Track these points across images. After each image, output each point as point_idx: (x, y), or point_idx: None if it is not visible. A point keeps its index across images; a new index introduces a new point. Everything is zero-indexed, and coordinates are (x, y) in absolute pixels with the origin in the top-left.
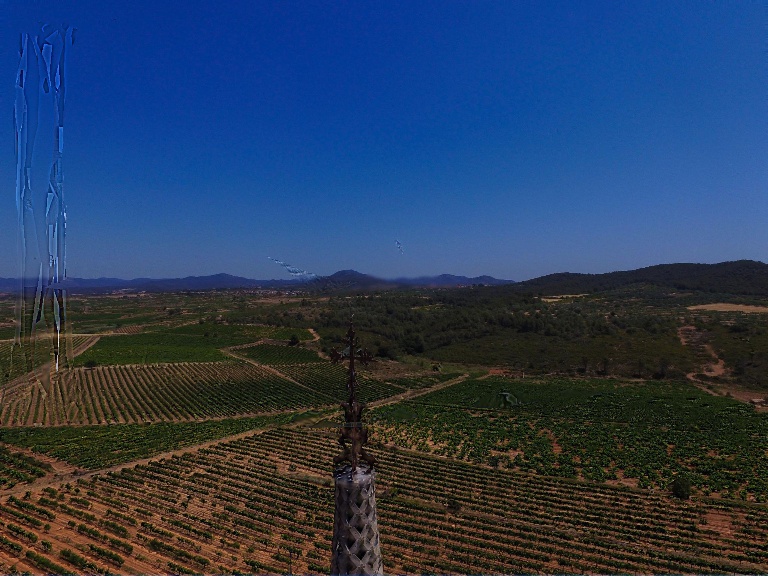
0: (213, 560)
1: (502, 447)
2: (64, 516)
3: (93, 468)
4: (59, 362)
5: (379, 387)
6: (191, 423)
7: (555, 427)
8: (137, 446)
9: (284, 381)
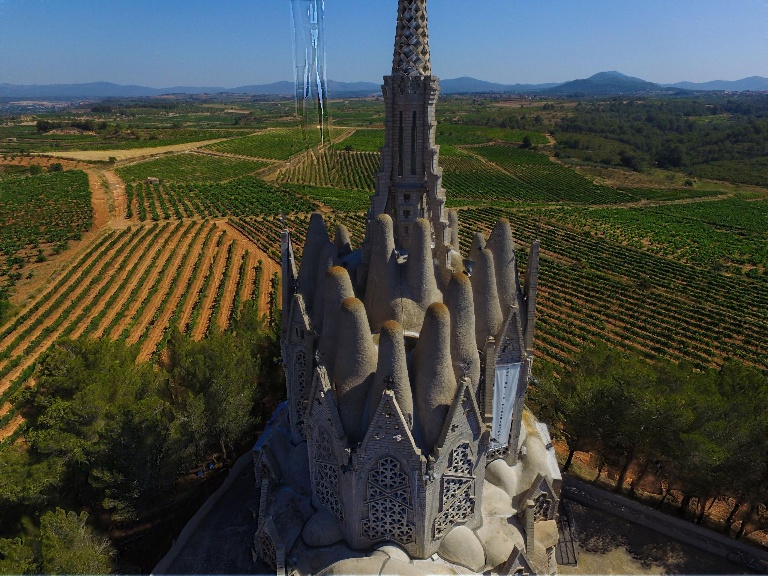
0: None
1: (737, 259)
2: None
3: (346, 212)
4: (324, 136)
5: (608, 193)
6: None
7: None
8: None
9: (507, 177)
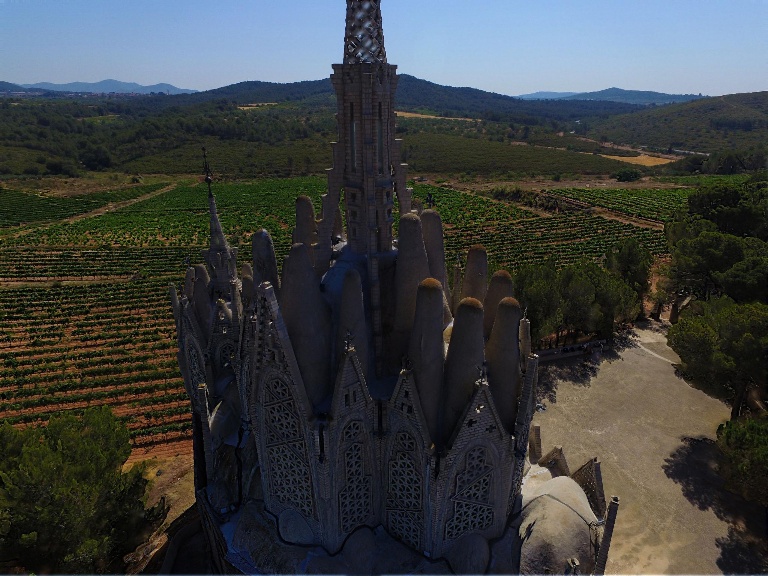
0: None
1: None
2: None
3: None
4: None
5: (68, 204)
6: None
7: (278, 212)
8: None
9: None
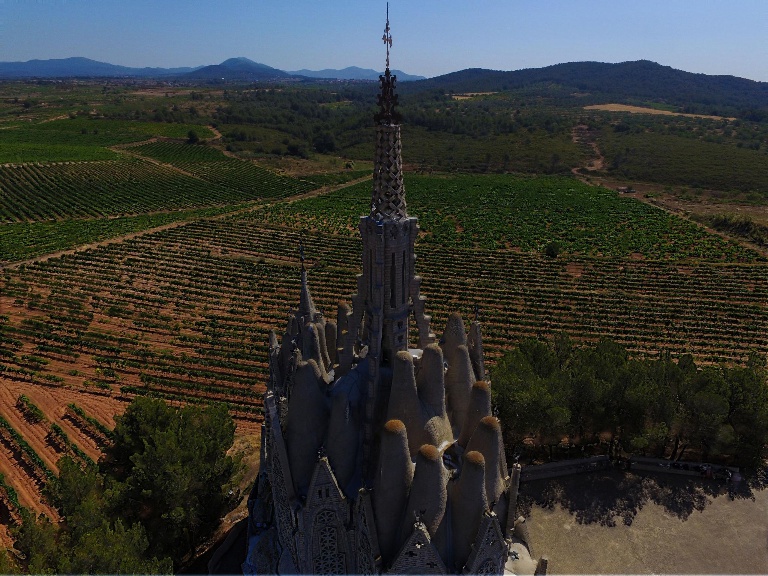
0: (173, 318)
1: None
2: (6, 298)
3: (13, 260)
4: None
5: (294, 184)
6: (103, 219)
7: (459, 213)
8: (52, 241)
9: (192, 179)
